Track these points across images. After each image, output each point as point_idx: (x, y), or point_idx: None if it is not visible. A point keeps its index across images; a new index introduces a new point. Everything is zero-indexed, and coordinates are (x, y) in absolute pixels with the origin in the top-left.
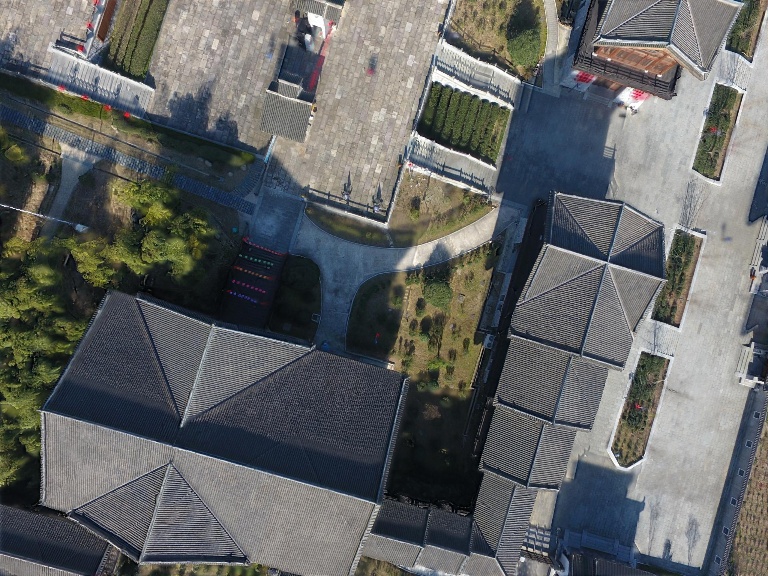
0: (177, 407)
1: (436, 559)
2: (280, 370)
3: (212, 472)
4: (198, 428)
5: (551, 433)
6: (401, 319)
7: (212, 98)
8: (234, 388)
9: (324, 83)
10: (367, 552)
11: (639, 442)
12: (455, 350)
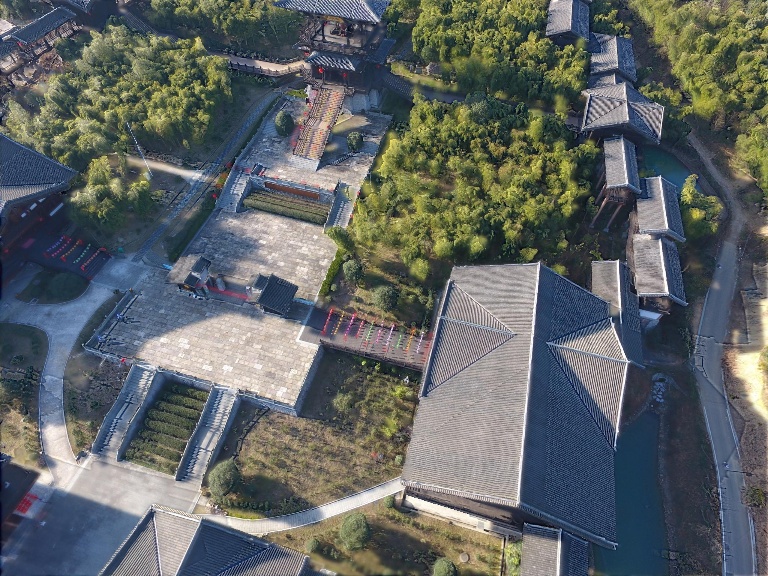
0: None
1: None
2: None
3: None
4: None
5: None
6: (3, 367)
7: (224, 240)
8: None
9: (221, 305)
10: None
11: None
12: None
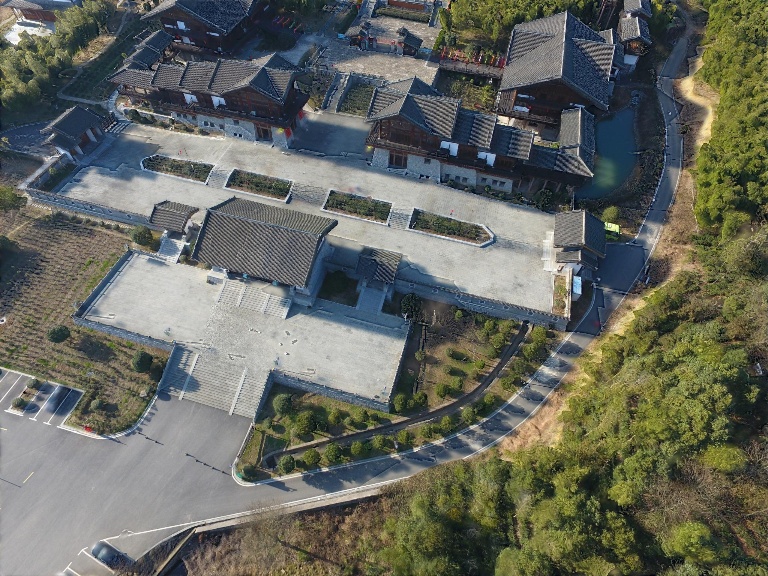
0: None
1: None
2: (240, 4)
3: None
4: None
5: None
6: None
7: None
8: None
9: (376, 53)
10: None
11: None
12: None
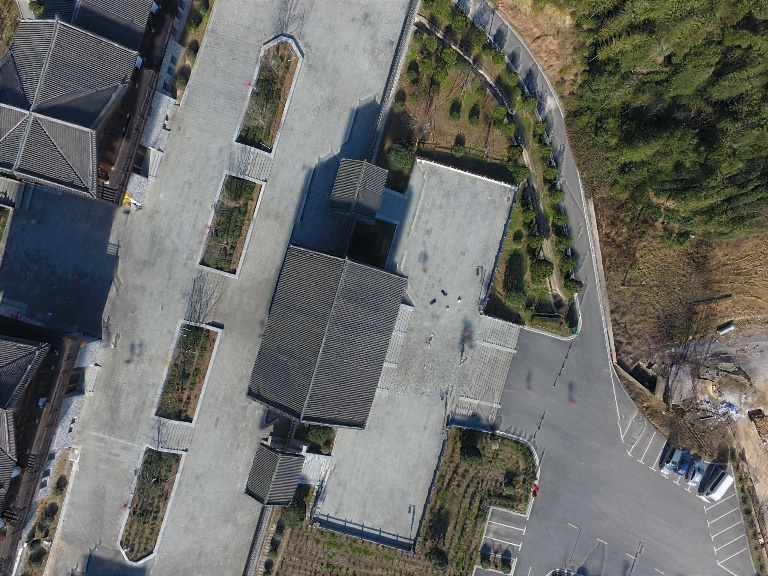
0: None
1: None
2: None
3: None
4: None
5: None
6: None
7: None
8: None
9: None
10: None
11: (148, 537)
12: None
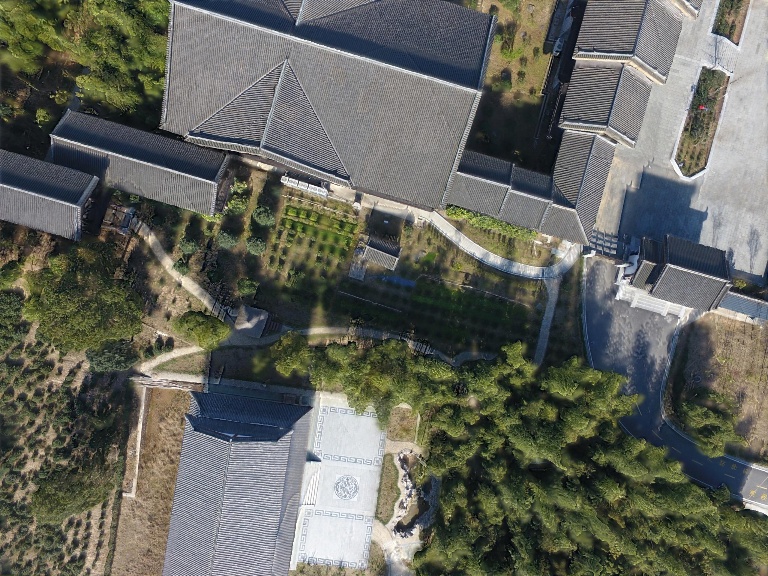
0: (291, 14)
1: (520, 209)
2: (379, 1)
3: (324, 70)
4: (311, 29)
5: (629, 82)
6: None
7: None
8: (340, 6)
9: None
10: (456, 199)
11: (701, 153)
12: (526, 57)
